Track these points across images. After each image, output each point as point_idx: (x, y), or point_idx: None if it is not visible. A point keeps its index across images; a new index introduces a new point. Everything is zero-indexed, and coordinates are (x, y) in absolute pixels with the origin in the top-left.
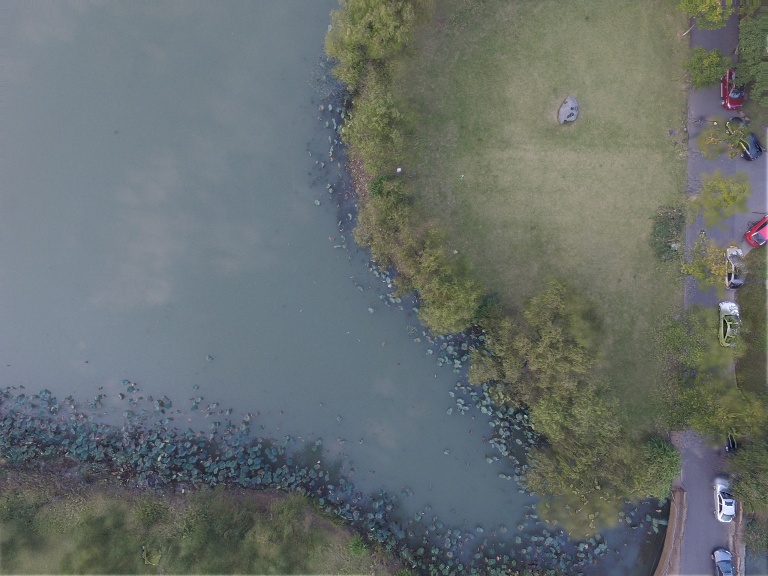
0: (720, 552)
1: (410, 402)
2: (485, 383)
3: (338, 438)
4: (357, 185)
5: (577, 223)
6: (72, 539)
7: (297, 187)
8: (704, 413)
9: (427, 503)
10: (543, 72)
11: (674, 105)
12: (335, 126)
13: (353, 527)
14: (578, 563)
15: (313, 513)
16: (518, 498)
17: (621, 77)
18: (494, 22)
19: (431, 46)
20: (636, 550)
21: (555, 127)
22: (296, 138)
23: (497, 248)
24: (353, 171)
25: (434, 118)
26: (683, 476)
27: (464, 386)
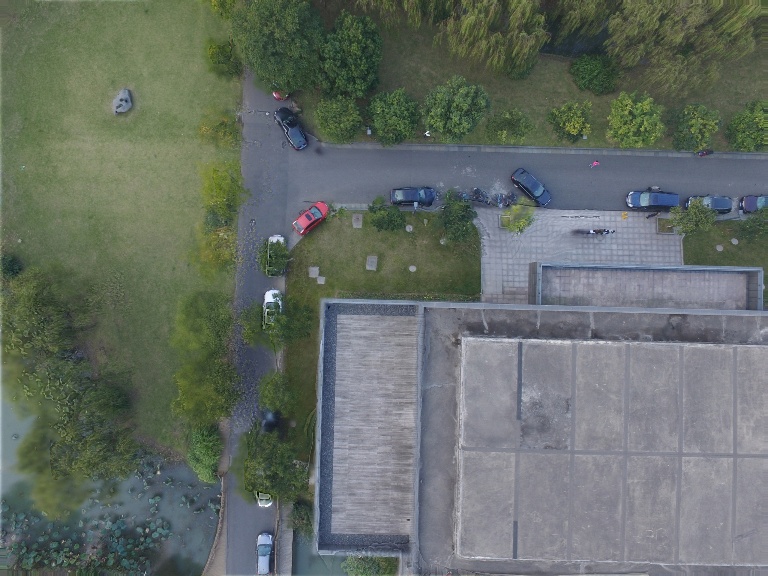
0: (262, 536)
1: None
2: (47, 369)
3: None
4: None
5: (133, 212)
6: None
7: None
8: (244, 399)
9: None
10: (102, 64)
11: (229, 96)
12: None
13: None
14: (138, 547)
15: None
16: (83, 482)
17: (178, 69)
18: (58, 16)
19: (2, 40)
20: (200, 534)
21: (113, 118)
22: None
23: (57, 237)
24: None
25: (1, 110)
26: (232, 461)
27: (28, 372)
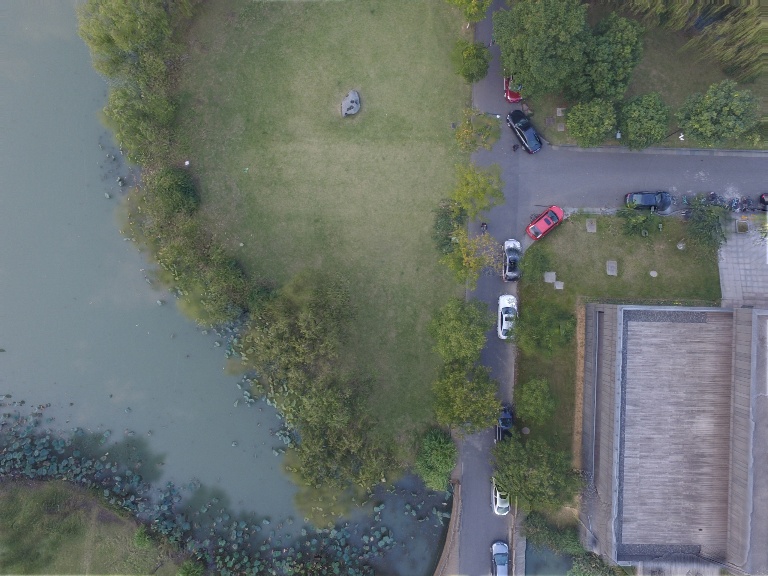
0: (498, 545)
1: (199, 394)
2: (270, 375)
3: (126, 430)
4: (147, 178)
5: (360, 216)
6: None
7: (89, 180)
8: (481, 406)
9: (215, 495)
10: (328, 65)
11: (458, 98)
12: None
13: (138, 519)
14: (363, 556)
15: (98, 504)
16: (305, 490)
17: (405, 70)
18: (281, 16)
19: (221, 40)
20: (424, 543)
21: (339, 120)
22: (89, 131)
23: (282, 241)
24: (144, 164)
25: (221, 111)
26: (464, 469)
27: (250, 378)
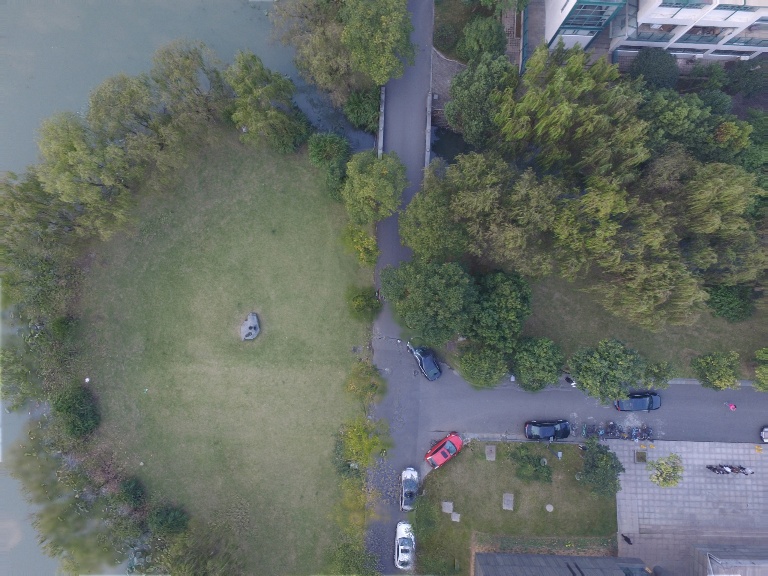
0: None
1: None
2: None
3: None
4: (48, 393)
5: (260, 439)
6: None
7: None
8: None
9: None
10: (228, 286)
11: (359, 321)
12: (22, 336)
13: None
14: None
15: None
16: None
17: (306, 292)
18: (181, 233)
19: (122, 254)
20: None
21: (239, 342)
22: None
23: (181, 462)
24: (44, 378)
25: (122, 329)
26: None
27: None
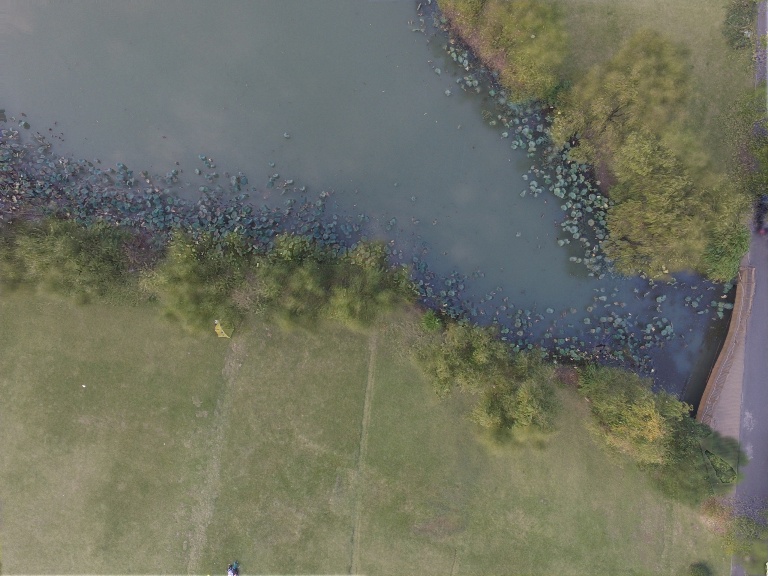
0: None
1: (483, 185)
2: (559, 166)
3: (412, 218)
4: None
5: (653, 10)
6: (144, 312)
7: None
8: None
9: (498, 284)
10: None
11: None
12: None
13: (426, 304)
14: (645, 345)
15: (387, 289)
16: (587, 281)
17: None
18: None
19: None
20: (700, 336)
21: None
22: None
23: (574, 33)
24: None
25: None
26: (750, 258)
27: (538, 169)
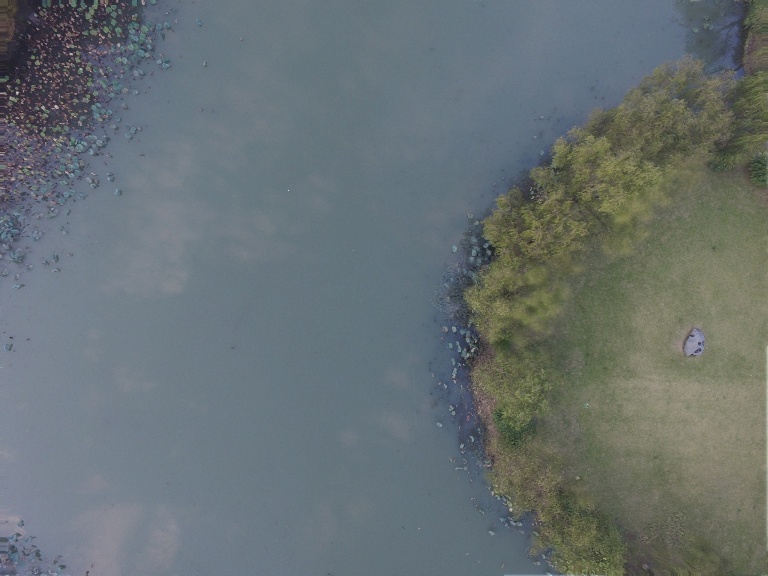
0: None
1: None
2: None
3: None
4: (479, 407)
5: (699, 453)
6: None
7: (418, 407)
8: None
9: None
10: (669, 302)
11: None
12: (460, 350)
13: None
14: None
15: None
16: None
17: (746, 308)
18: (621, 249)
19: (556, 269)
20: None
21: (680, 357)
22: (418, 357)
23: (619, 476)
24: (475, 393)
25: (559, 344)
26: None
27: None
